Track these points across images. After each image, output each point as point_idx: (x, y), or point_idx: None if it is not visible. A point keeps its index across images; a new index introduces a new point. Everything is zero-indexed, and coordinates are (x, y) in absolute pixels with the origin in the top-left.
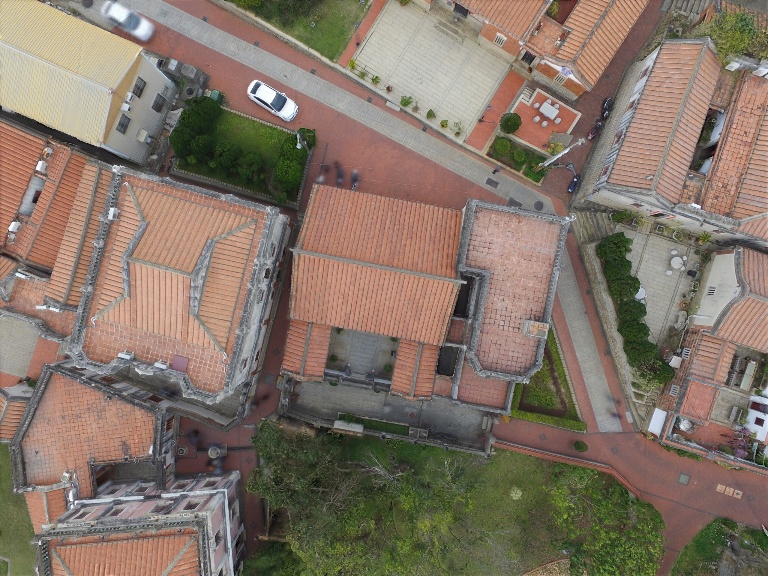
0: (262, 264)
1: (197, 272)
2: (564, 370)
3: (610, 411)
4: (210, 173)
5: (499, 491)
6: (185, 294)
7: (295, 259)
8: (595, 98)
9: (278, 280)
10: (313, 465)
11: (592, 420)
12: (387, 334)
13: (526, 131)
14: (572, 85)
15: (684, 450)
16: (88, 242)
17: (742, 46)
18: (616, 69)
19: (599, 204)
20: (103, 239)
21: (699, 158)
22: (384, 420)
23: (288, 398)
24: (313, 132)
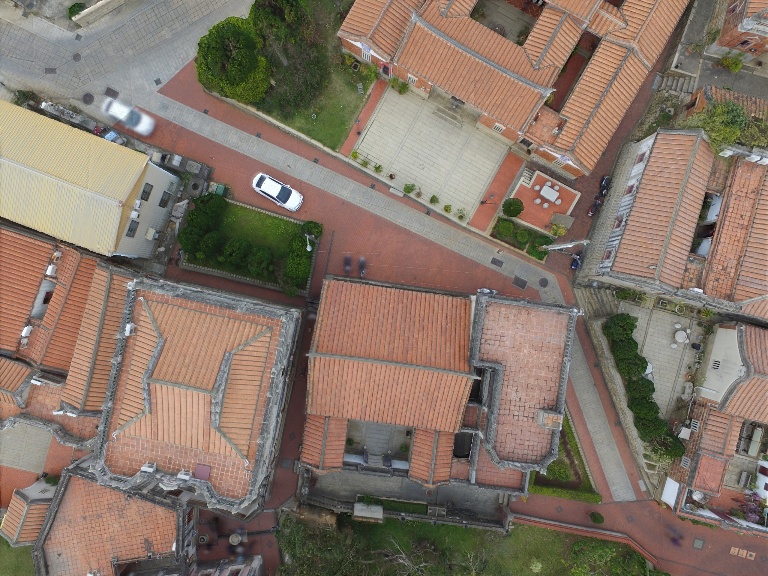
0: (279, 370)
1: (217, 389)
2: (576, 442)
3: (623, 480)
4: (219, 266)
5: (518, 562)
6: (206, 409)
7: (311, 361)
8: (593, 175)
9: (291, 368)
10: (338, 562)
11: (606, 490)
12: (403, 424)
13: (528, 213)
14: (571, 169)
15: (698, 520)
16: (103, 347)
17: (735, 137)
18: (612, 147)
19: (603, 282)
20: (121, 354)
21: (697, 234)
22: (402, 499)
23: (307, 486)
24: (320, 227)
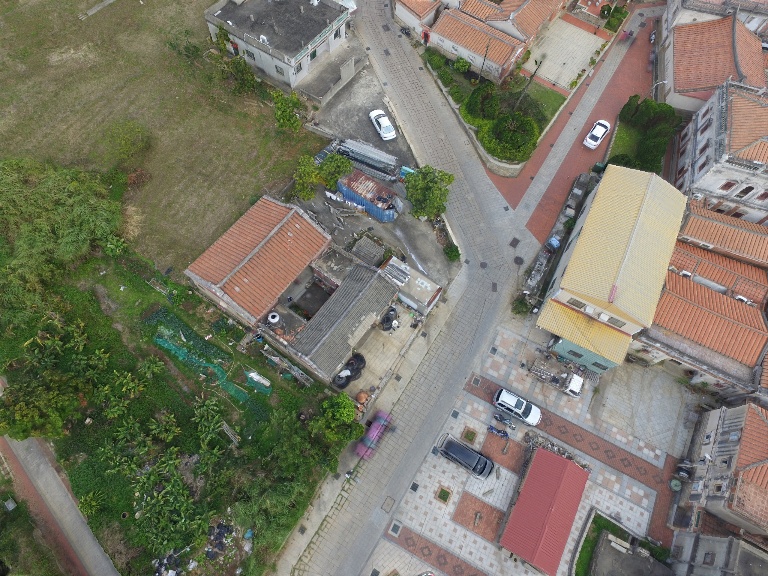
0: None
1: None
2: None
3: None
4: None
5: None
6: None
7: None
8: None
9: None
10: None
11: None
12: (763, 64)
13: None
14: None
15: None
16: None
17: None
18: None
19: None
20: None
21: None
22: None
23: None
24: (633, 96)
